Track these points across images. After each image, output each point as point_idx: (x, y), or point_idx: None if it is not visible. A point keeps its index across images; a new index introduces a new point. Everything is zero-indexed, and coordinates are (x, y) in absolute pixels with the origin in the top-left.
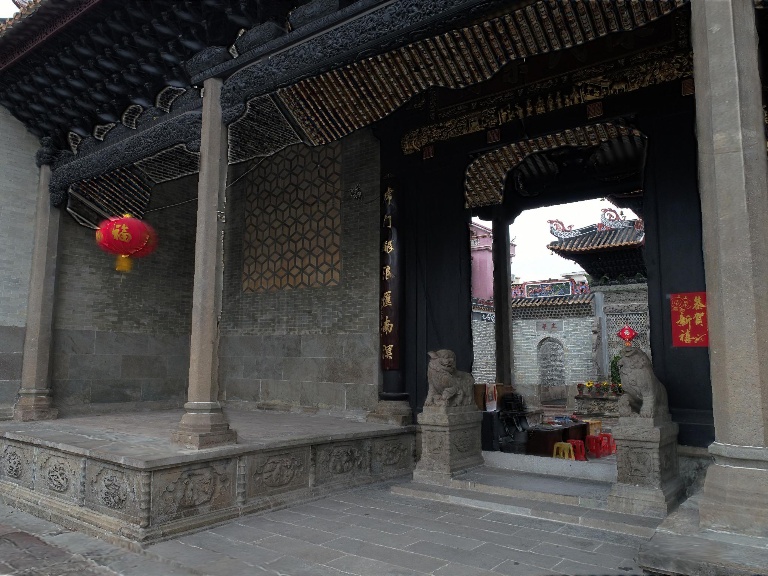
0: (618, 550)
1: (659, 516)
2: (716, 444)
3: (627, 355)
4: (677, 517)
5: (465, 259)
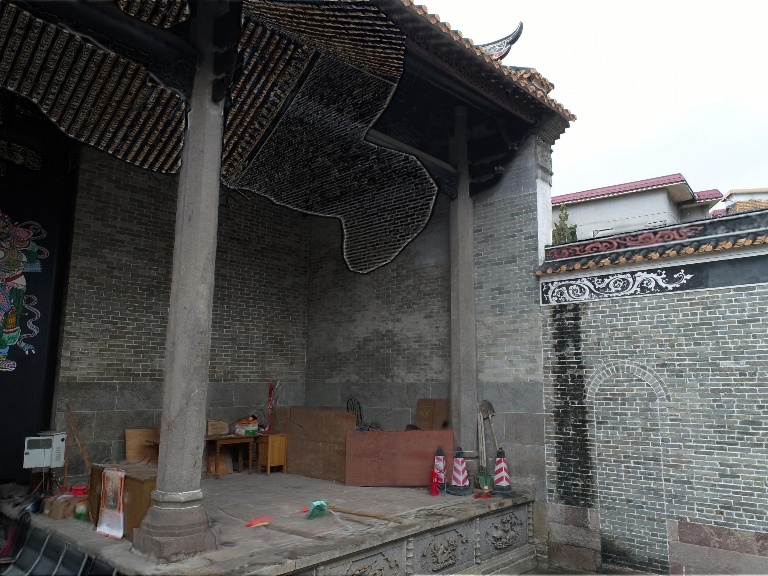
0: None
1: None
2: None
3: None
4: None
5: None
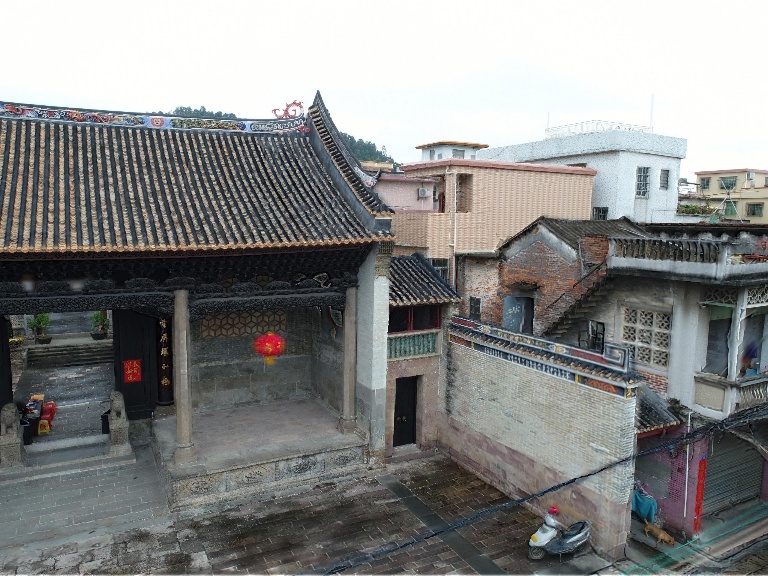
0: (126, 473)
1: (129, 454)
2: (178, 444)
3: (116, 396)
4: (169, 464)
5: (7, 345)
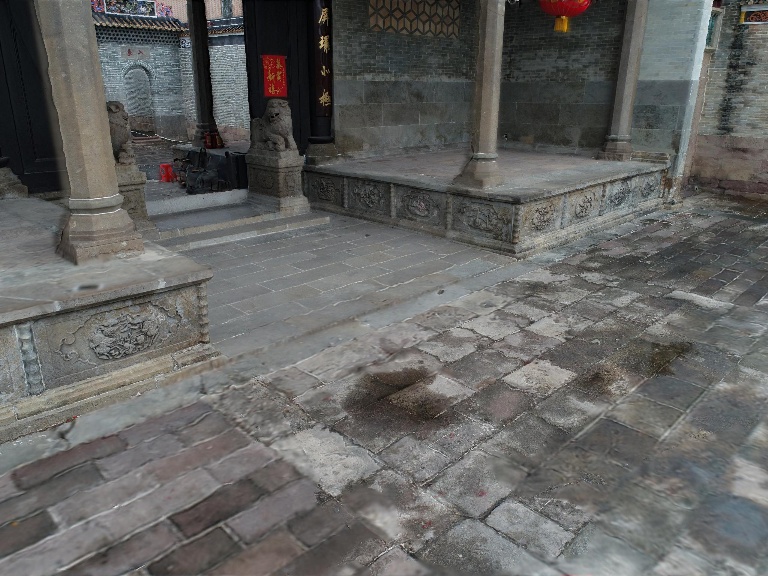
0: None
1: (307, 212)
2: (480, 154)
3: (284, 106)
4: None
5: None
